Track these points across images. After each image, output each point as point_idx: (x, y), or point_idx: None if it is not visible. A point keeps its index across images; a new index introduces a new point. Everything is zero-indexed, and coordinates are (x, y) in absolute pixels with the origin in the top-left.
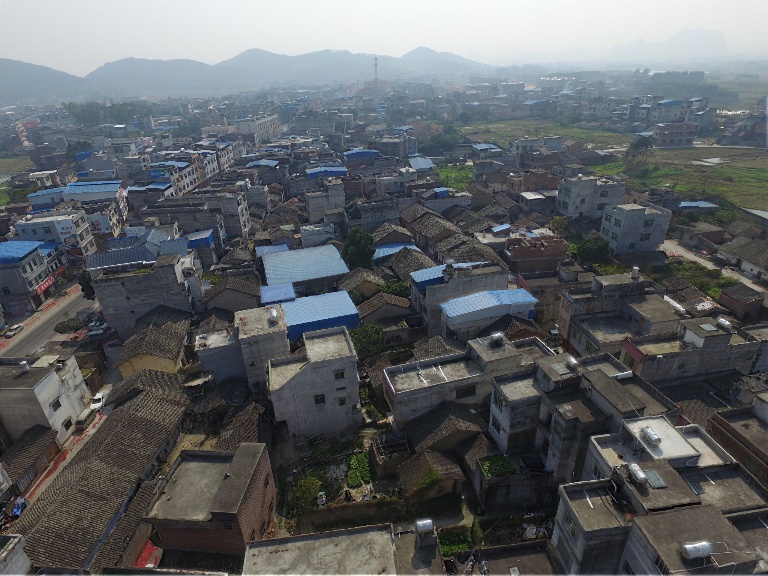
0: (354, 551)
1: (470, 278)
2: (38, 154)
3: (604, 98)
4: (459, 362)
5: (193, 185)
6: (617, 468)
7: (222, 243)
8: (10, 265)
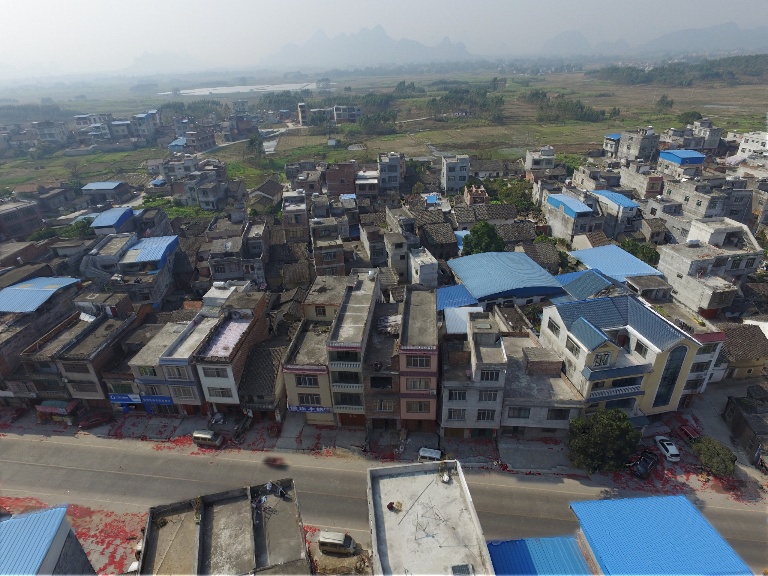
0: None
1: None
2: None
3: (54, 121)
4: None
5: None
6: (760, 183)
7: None
8: None
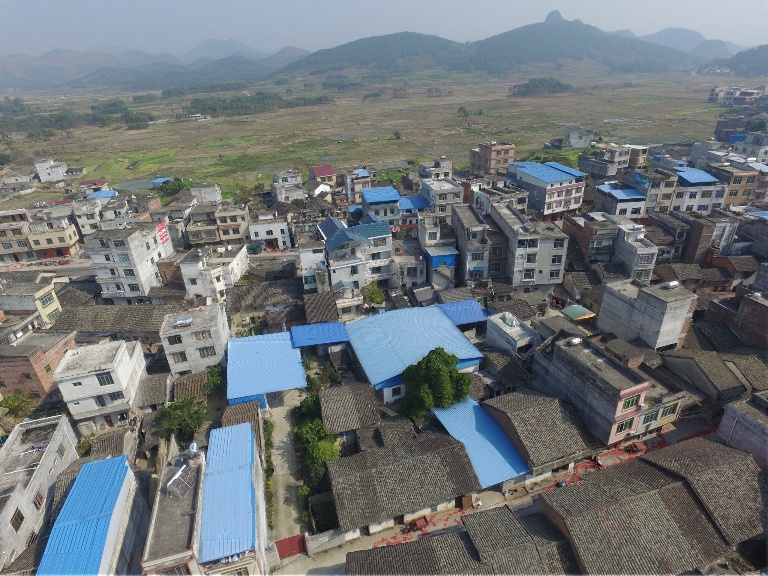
0: None
1: (159, 492)
2: (724, 126)
3: None
4: (24, 489)
5: (707, 211)
6: None
7: (468, 274)
8: None
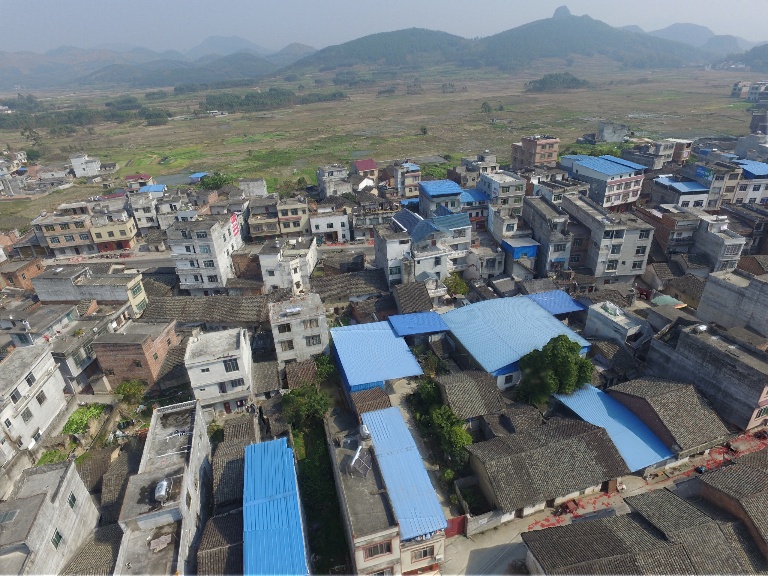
0: (5, 383)
1: None
2: (760, 120)
3: None
4: None
5: None
6: None
7: (548, 265)
8: (429, 198)
